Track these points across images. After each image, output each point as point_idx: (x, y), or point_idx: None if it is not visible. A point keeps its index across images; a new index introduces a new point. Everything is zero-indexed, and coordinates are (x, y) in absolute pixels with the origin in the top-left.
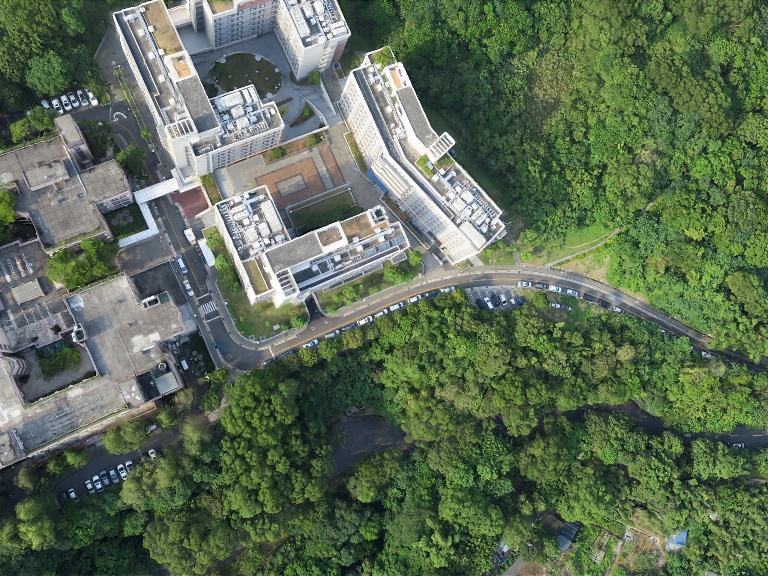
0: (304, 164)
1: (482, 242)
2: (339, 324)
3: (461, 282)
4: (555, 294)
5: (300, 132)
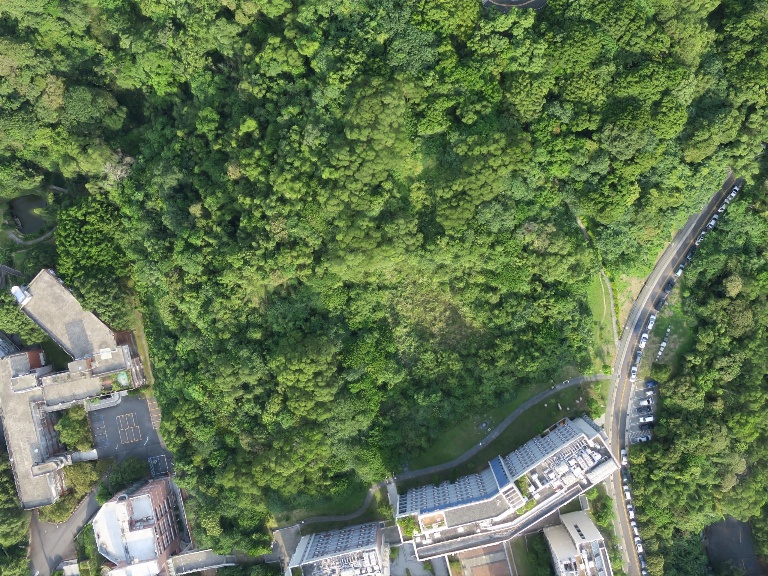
0: (477, 575)
1: (613, 466)
2: (636, 568)
3: (618, 440)
4: (648, 341)
5: (441, 567)
